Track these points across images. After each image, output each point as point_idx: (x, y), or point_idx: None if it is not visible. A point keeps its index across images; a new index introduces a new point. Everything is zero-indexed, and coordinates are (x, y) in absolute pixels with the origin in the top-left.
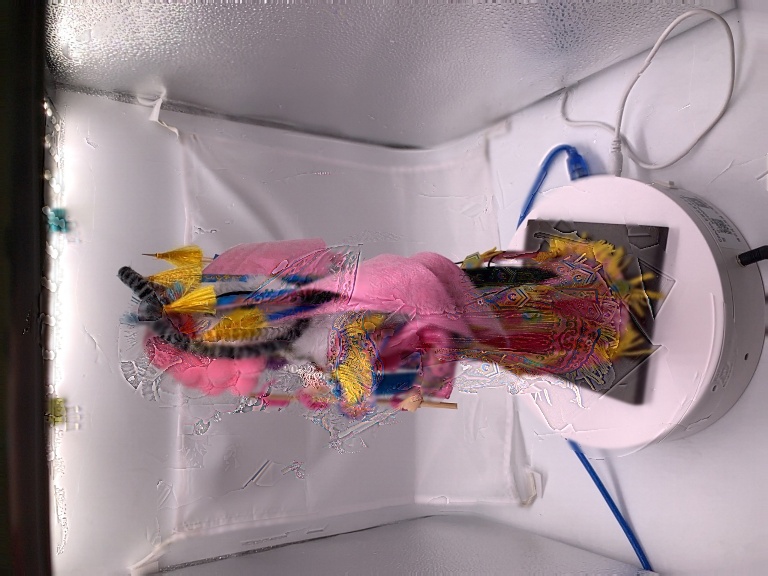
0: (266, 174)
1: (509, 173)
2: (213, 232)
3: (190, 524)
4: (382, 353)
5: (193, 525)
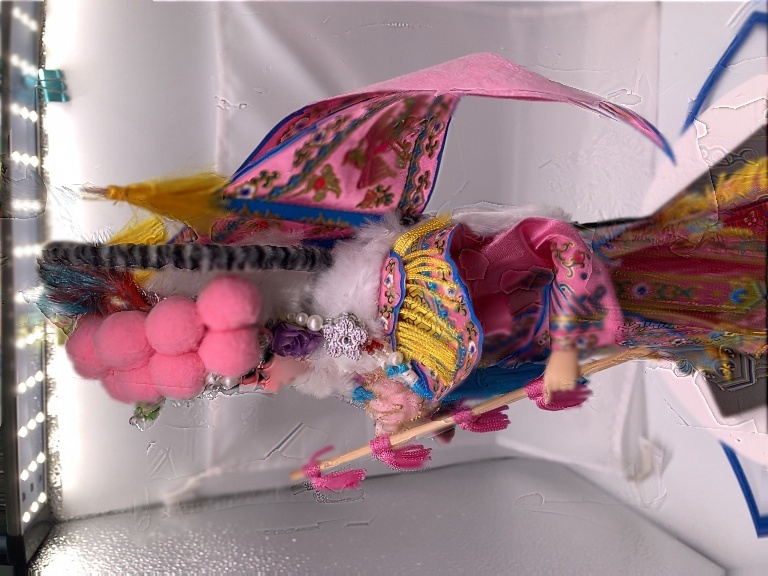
0: (319, 25)
1: (677, 36)
2: (242, 107)
3: (186, 506)
4: (478, 304)
5: (190, 508)
